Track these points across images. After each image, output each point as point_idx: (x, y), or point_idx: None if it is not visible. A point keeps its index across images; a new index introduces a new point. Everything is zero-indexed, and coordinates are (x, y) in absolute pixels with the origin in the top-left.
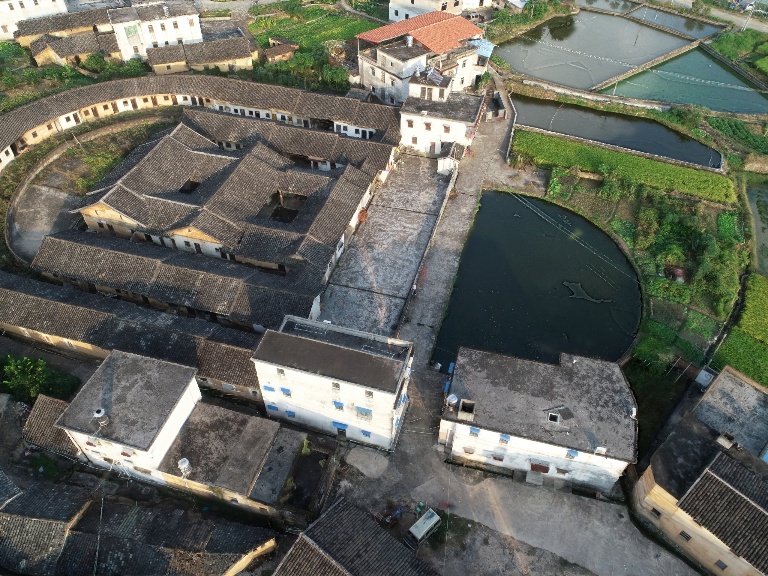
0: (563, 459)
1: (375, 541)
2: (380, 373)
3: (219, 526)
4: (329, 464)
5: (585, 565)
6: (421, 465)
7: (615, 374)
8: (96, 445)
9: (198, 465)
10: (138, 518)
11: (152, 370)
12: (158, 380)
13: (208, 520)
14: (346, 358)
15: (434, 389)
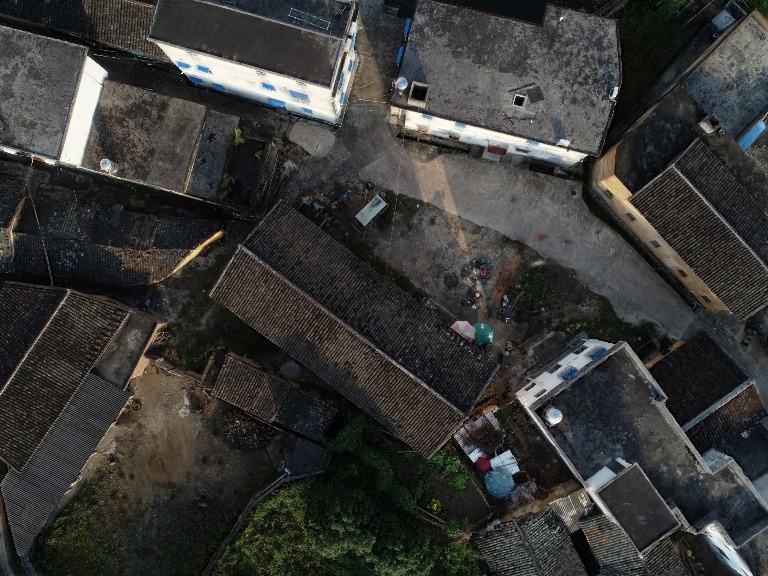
0: (523, 143)
1: (316, 246)
2: (311, 57)
3: (162, 221)
4: (267, 154)
5: (526, 242)
6: (371, 141)
7: (608, 36)
8: (1, 148)
9: (124, 160)
10: (78, 216)
11: (31, 50)
12: (43, 65)
13: (150, 215)
14: (268, 35)
15: (389, 42)
